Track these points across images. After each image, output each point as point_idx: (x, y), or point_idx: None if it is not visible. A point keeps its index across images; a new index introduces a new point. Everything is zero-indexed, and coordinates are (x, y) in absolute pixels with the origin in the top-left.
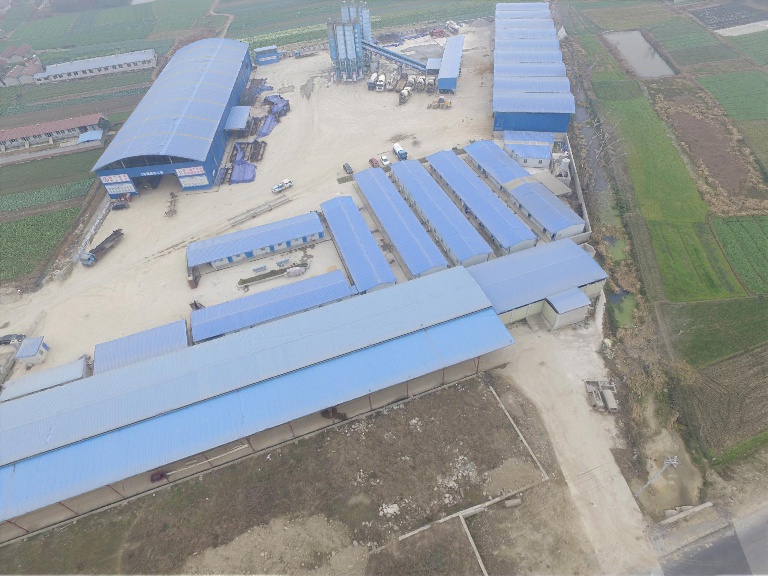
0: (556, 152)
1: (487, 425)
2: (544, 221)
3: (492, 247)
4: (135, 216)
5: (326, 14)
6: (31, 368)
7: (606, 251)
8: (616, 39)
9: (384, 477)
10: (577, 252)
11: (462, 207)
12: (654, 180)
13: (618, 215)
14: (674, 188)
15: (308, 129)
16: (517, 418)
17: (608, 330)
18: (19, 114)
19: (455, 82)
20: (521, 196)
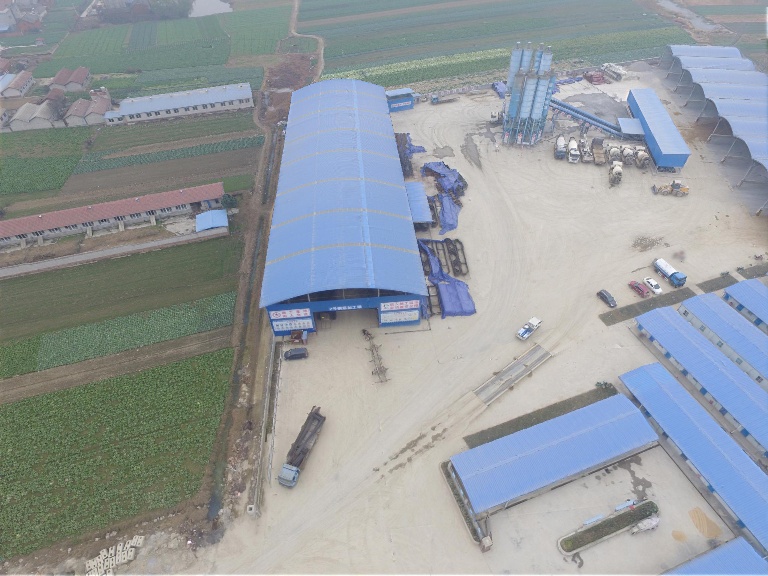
0: None
1: None
2: None
3: None
4: (324, 374)
5: (439, 43)
6: None
7: None
8: None
9: None
10: None
11: None
12: None
13: None
14: None
15: (507, 220)
16: None
17: None
18: (96, 172)
19: (685, 159)
20: None
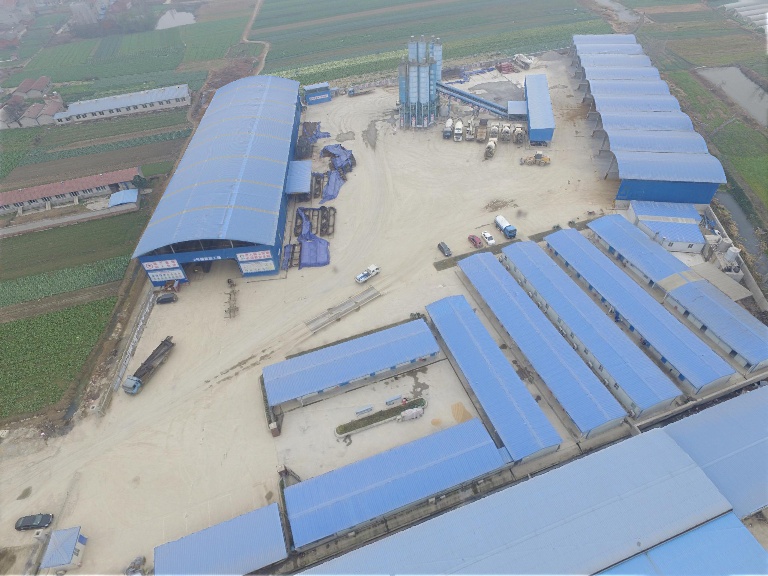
0: (701, 230)
1: None
2: (735, 343)
3: None
4: (186, 314)
5: (373, 43)
6: None
7: None
8: None
9: None
10: None
11: (609, 312)
12: None
13: None
14: None
15: (382, 190)
16: None
17: None
18: (38, 164)
19: (551, 133)
20: (689, 301)
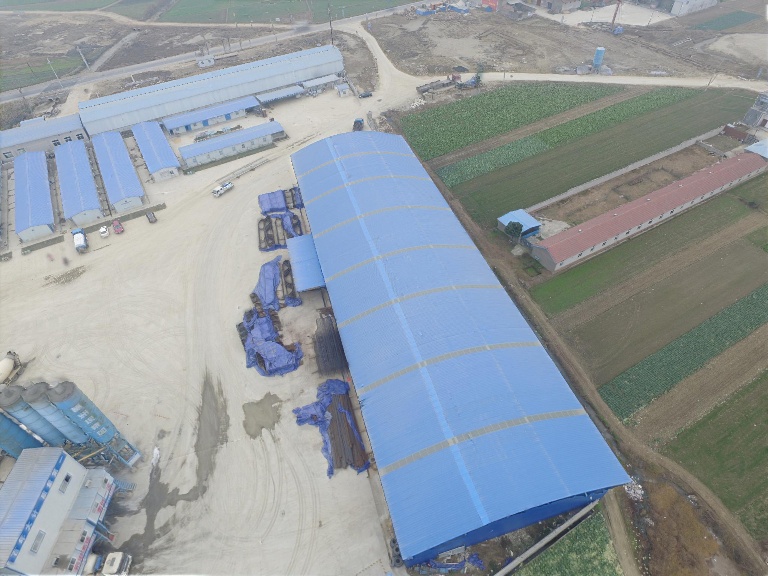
0: None
1: None
2: None
3: (52, 164)
4: None
5: None
6: None
7: None
8: None
9: None
10: None
11: None
12: None
13: None
14: None
15: (202, 283)
16: None
17: None
18: (766, 278)
19: None
20: None
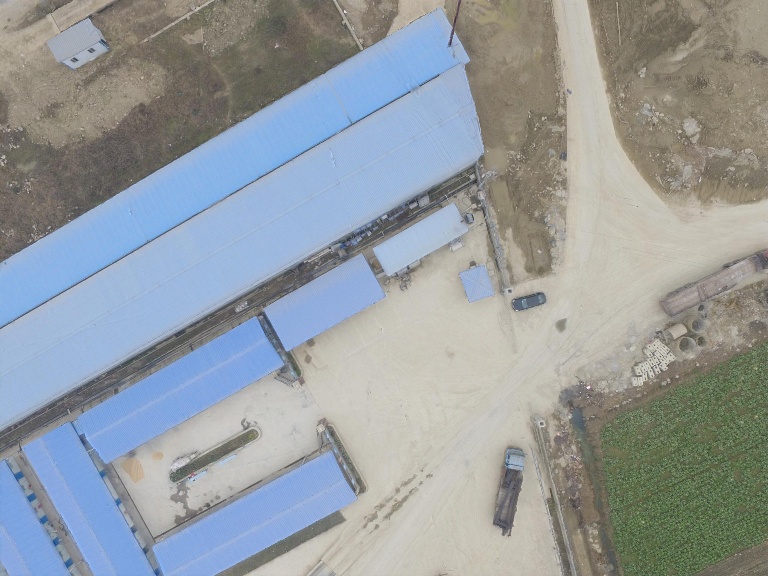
0: None
1: None
2: None
3: None
4: None
5: None
6: (470, 265)
7: None
8: None
9: (5, 189)
10: None
11: None
12: None
13: None
14: None
15: None
16: None
17: None
18: None
19: None
20: None
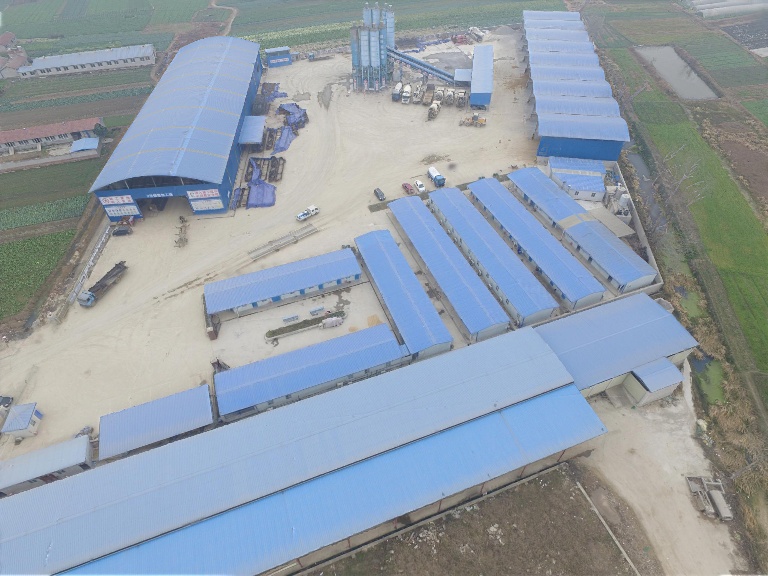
0: (607, 183)
1: (581, 536)
2: (611, 269)
3: (553, 297)
4: (140, 244)
5: (338, 12)
6: (20, 442)
7: (680, 305)
8: (648, 54)
9: None
10: (659, 312)
11: (513, 246)
12: (718, 220)
13: (685, 261)
14: (741, 230)
15: (330, 145)
16: (614, 526)
17: (700, 408)
18: (2, 113)
19: (489, 97)
20: (580, 237)
